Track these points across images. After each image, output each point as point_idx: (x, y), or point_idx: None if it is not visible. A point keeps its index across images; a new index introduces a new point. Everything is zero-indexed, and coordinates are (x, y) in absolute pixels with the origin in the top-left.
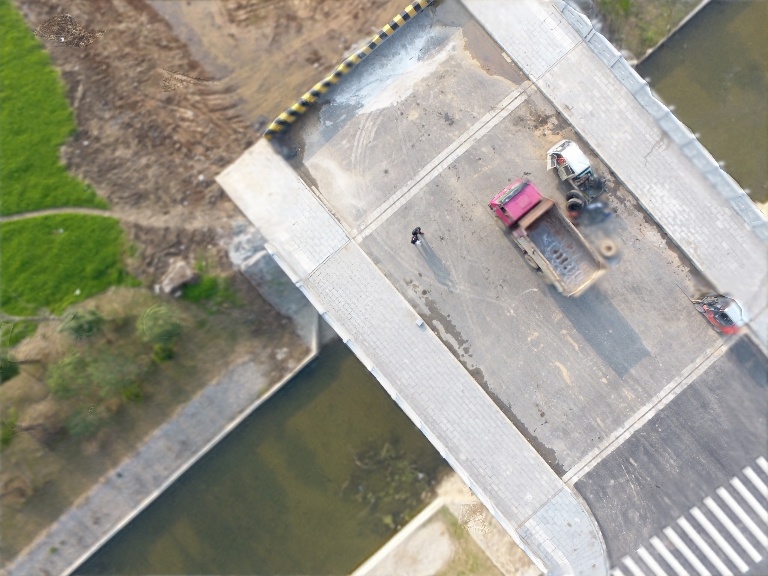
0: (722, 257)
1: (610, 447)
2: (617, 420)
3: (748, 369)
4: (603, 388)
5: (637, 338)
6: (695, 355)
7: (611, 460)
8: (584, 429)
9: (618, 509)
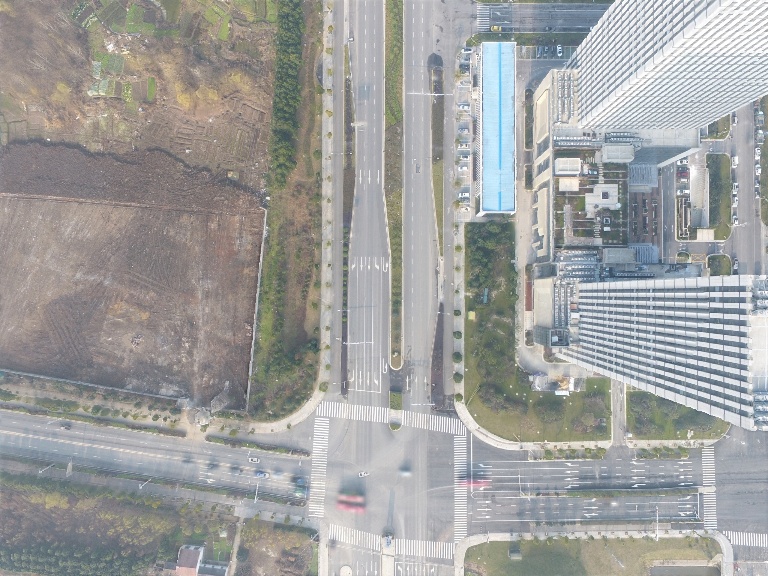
0: (730, 572)
1: (760, 561)
2: (757, 564)
3: (737, 556)
4: (756, 569)
5: (747, 571)
6: (742, 563)
7: (762, 560)
8: (762, 567)
9: (766, 553)
